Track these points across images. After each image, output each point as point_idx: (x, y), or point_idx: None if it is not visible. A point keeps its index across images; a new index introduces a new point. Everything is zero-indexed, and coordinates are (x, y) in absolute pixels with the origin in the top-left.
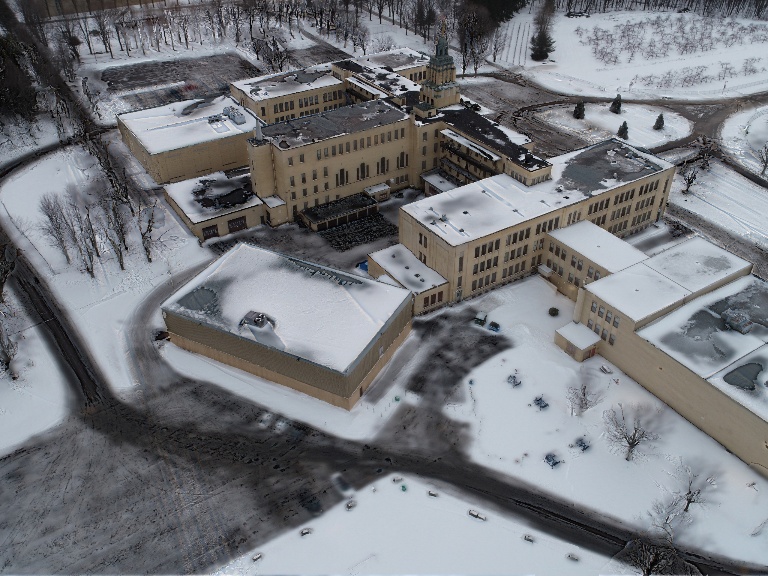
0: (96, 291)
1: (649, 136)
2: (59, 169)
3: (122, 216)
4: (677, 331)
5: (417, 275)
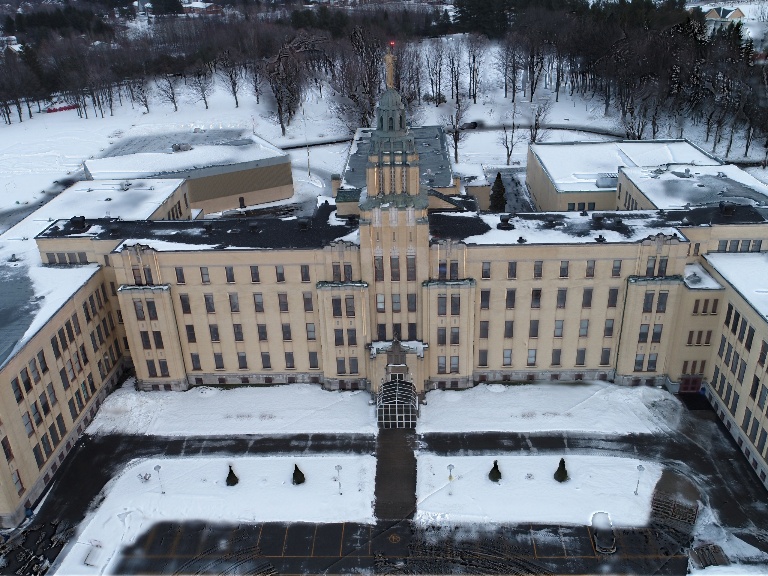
0: None
1: None
2: None
3: None
4: None
5: None
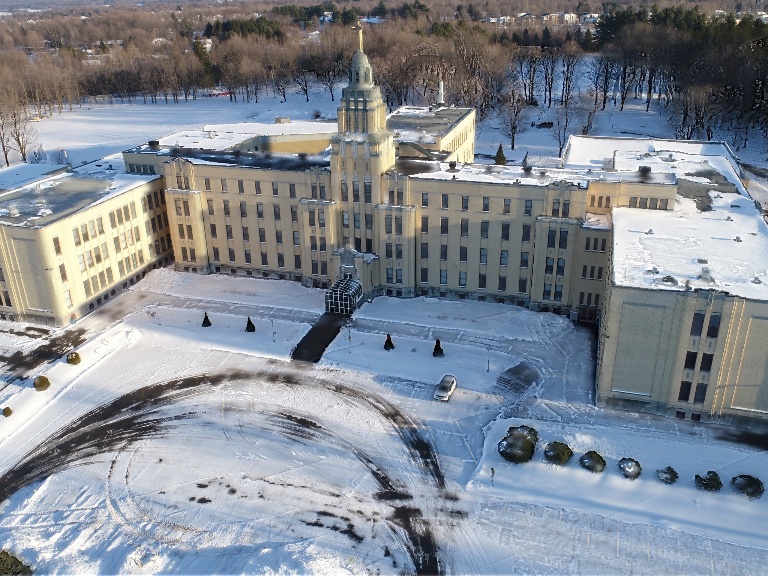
0: None
1: None
2: None
3: None
4: None
5: None
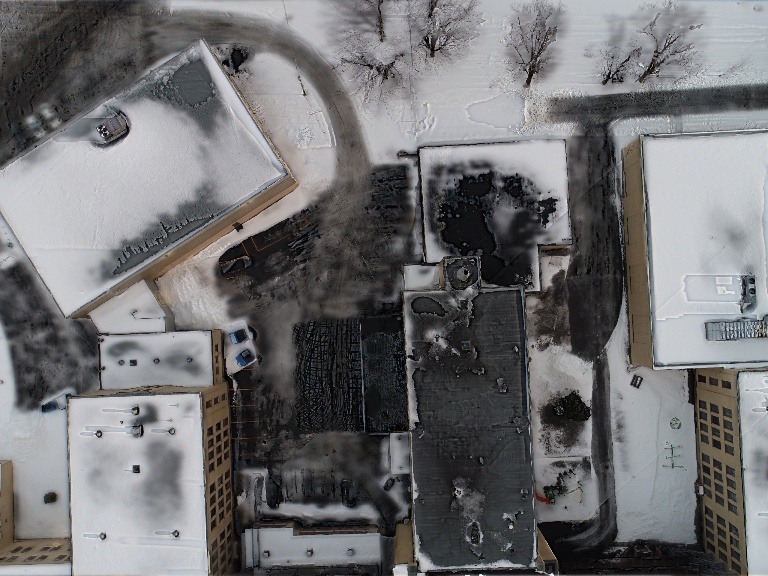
0: None
1: None
2: (759, 9)
3: (456, 46)
4: None
5: (134, 362)
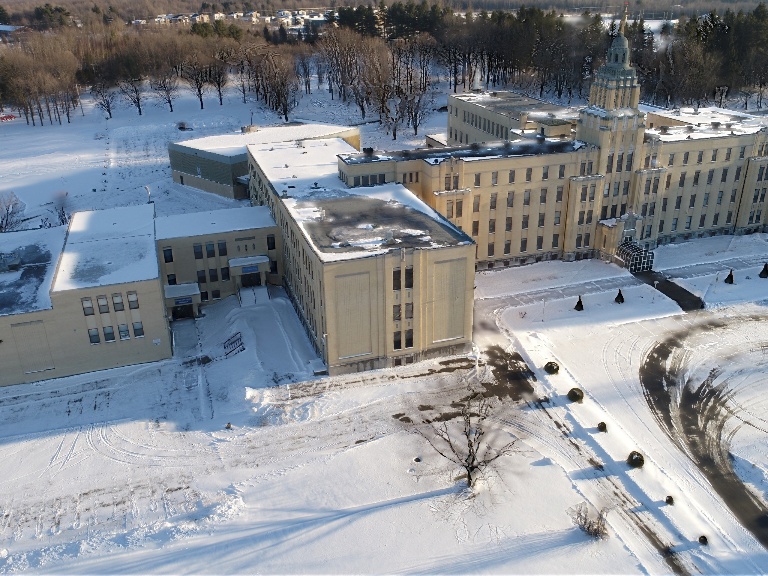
0: (363, 131)
1: None
2: None
3: None
4: (46, 241)
5: None
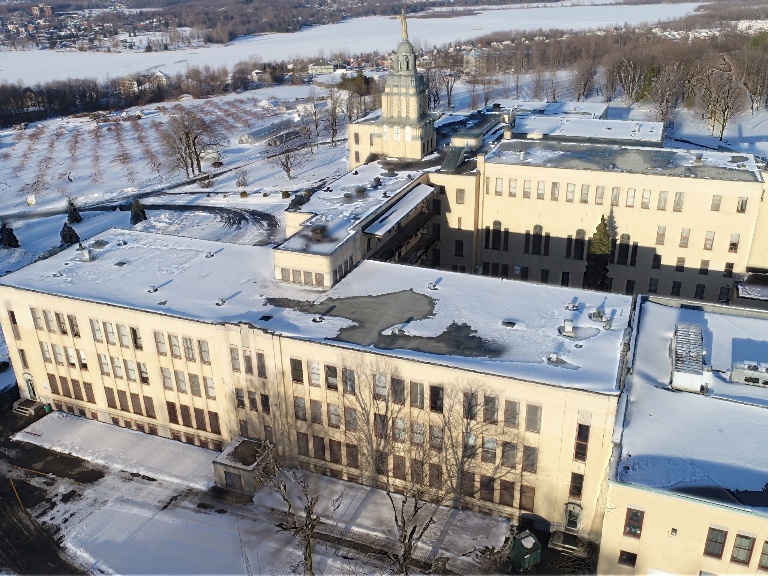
0: None
1: (119, 216)
2: None
3: None
4: None
5: None
